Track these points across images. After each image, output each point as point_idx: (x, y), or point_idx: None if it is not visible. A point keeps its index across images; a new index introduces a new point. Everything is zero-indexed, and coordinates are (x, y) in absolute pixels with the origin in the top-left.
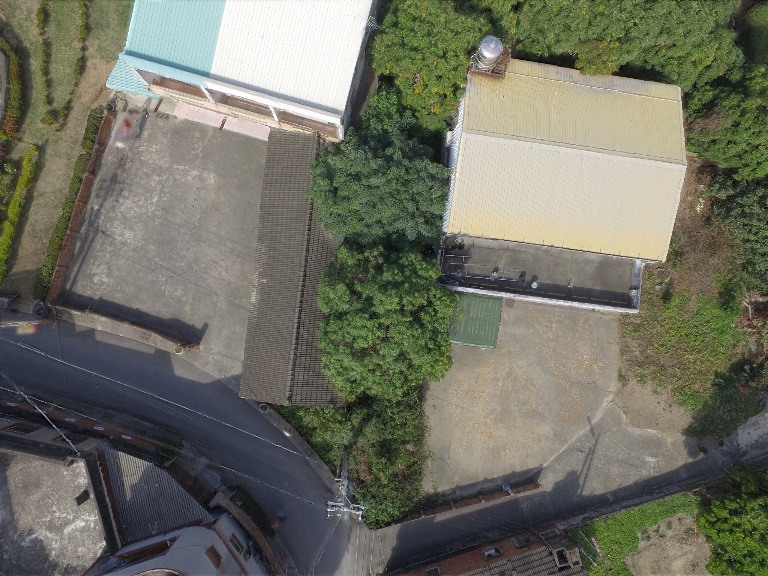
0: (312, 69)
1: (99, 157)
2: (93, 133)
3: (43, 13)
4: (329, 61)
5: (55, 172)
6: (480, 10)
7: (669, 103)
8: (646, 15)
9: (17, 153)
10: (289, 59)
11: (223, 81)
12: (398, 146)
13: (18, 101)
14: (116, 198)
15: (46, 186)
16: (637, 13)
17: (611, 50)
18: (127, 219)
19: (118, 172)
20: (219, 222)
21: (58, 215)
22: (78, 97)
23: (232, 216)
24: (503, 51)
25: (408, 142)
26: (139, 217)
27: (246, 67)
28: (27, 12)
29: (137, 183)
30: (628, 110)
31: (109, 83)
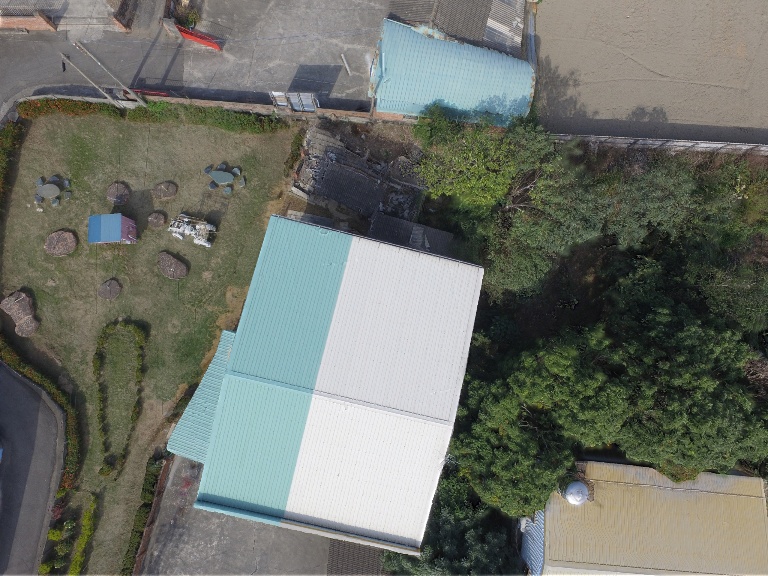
0: (389, 502)
1: (158, 503)
2: (152, 483)
3: (99, 360)
4: (406, 493)
5: (114, 519)
6: (558, 426)
7: (752, 500)
8: (734, 447)
9: (75, 502)
10: (365, 494)
11: (298, 517)
12: (474, 555)
13: (76, 456)
14: (175, 543)
15: (105, 534)
16: (726, 449)
17: (696, 470)
18: (187, 565)
19: (177, 516)
20: (280, 563)
21: (117, 563)
22: (135, 440)
23: (293, 556)
24: (588, 495)
25: (484, 547)
26: (199, 562)
27: (321, 503)
28: (82, 355)
29: (196, 527)
30: (717, 542)
31: (170, 447)
